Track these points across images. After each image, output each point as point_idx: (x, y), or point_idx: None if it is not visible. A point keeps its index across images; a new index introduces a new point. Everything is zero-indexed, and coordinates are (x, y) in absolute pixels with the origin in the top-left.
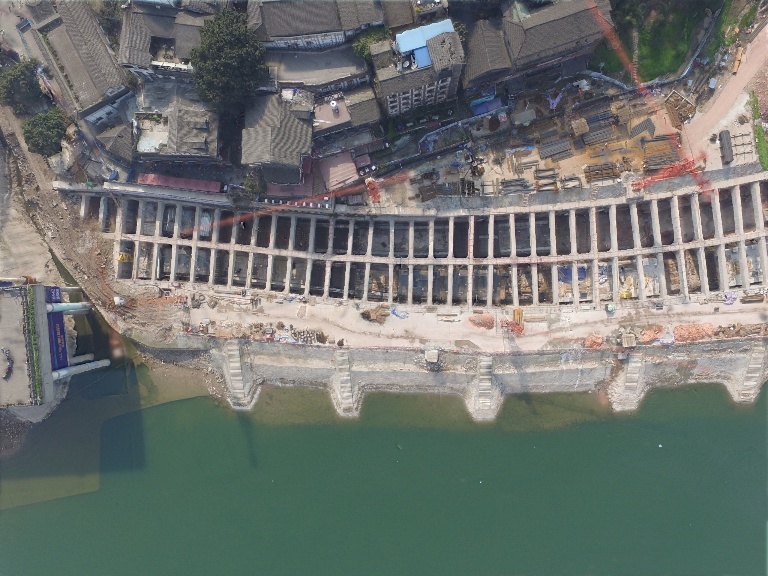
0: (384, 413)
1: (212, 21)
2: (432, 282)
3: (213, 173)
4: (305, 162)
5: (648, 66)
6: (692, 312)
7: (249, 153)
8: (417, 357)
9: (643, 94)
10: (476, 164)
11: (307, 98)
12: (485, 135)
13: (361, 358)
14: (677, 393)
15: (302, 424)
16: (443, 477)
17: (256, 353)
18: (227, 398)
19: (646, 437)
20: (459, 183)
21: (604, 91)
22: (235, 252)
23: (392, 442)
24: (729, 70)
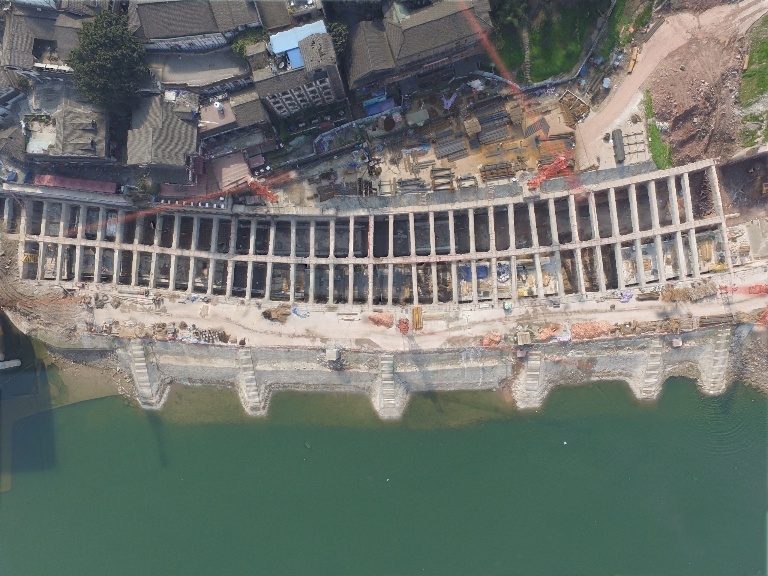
0: (292, 412)
1: (91, 23)
2: (333, 281)
3: (110, 174)
4: (196, 163)
5: (540, 66)
6: (589, 310)
7: (133, 154)
8: (319, 356)
9: (537, 94)
10: (373, 164)
11: (191, 99)
12: (380, 135)
13: (264, 357)
14: (581, 390)
15: (211, 423)
16: (350, 475)
17: (161, 353)
18: (136, 398)
19: (551, 434)
20: (357, 183)
21: (498, 91)
22: (139, 252)
23: (300, 440)
24: (624, 70)
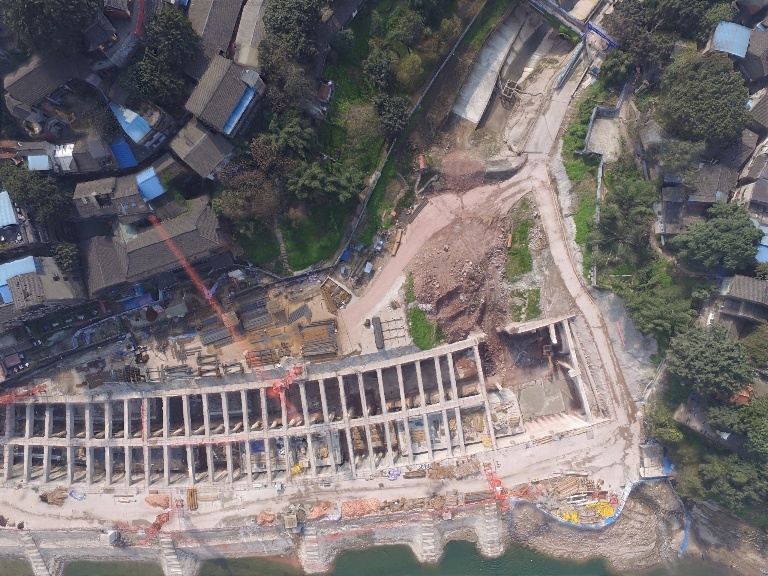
0: None
1: None
2: (109, 463)
3: None
4: None
5: (296, 258)
6: (359, 488)
7: None
8: (99, 536)
9: (299, 281)
10: (139, 352)
11: None
12: (142, 326)
13: (46, 537)
14: (367, 554)
15: None
16: None
17: None
18: None
19: None
20: (124, 370)
21: (259, 280)
22: None
23: None
24: (389, 251)
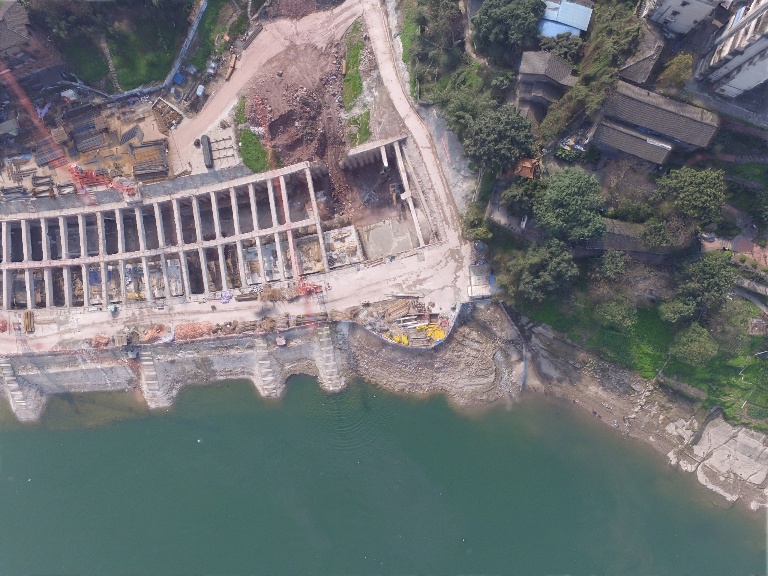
0: None
1: None
2: None
3: None
4: None
5: (124, 75)
6: (192, 311)
7: None
8: None
9: (130, 102)
10: None
11: None
12: None
13: None
14: (211, 389)
15: None
16: None
17: None
18: None
19: (187, 433)
20: None
21: (90, 100)
22: None
23: None
24: (223, 77)
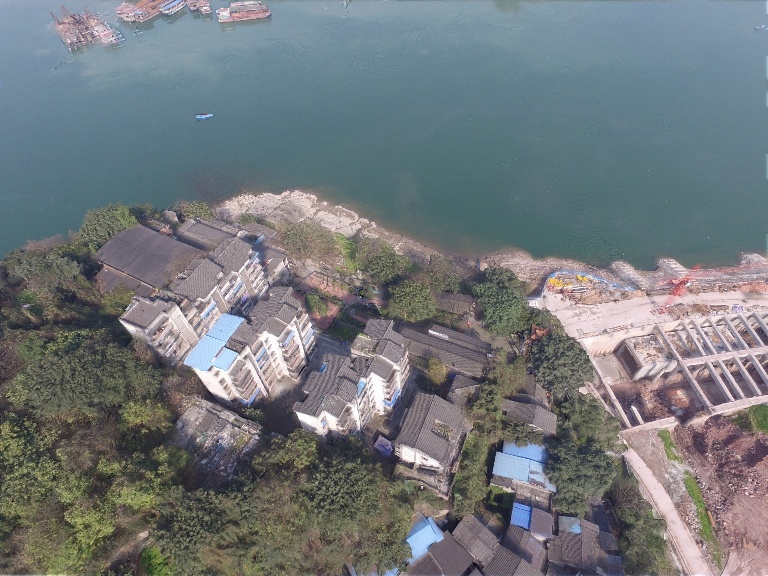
0: None
1: None
2: None
3: None
4: None
5: None
6: (762, 300)
7: None
8: None
9: None
10: None
11: None
12: None
13: None
14: None
15: None
16: None
17: None
18: None
19: None
20: None
21: None
22: None
23: None
24: None
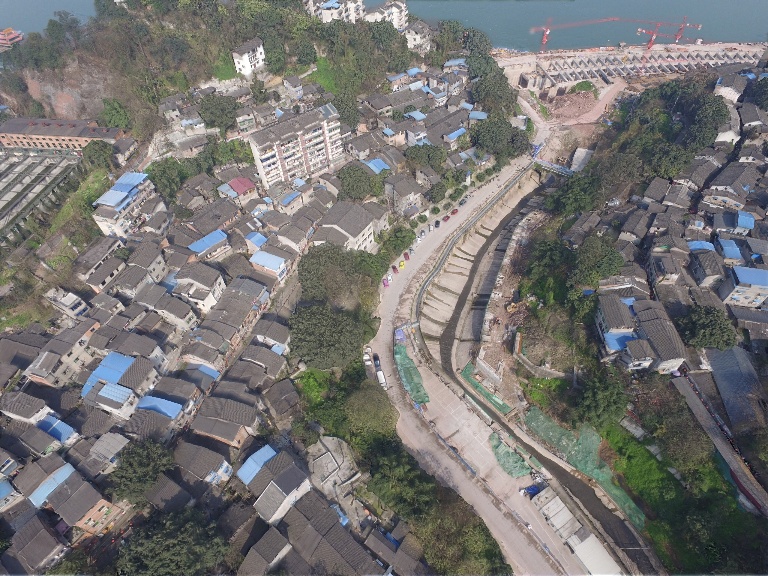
0: None
1: None
2: None
3: None
4: None
5: None
6: None
7: None
8: None
9: None
10: None
11: None
12: None
13: None
14: None
15: None
16: None
17: None
18: None
19: None
20: None
21: None
22: None
23: (692, 40)
24: None
